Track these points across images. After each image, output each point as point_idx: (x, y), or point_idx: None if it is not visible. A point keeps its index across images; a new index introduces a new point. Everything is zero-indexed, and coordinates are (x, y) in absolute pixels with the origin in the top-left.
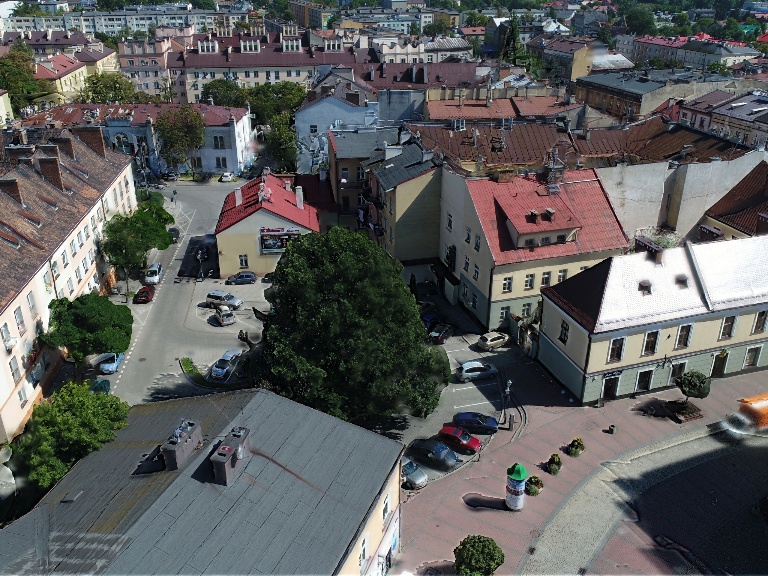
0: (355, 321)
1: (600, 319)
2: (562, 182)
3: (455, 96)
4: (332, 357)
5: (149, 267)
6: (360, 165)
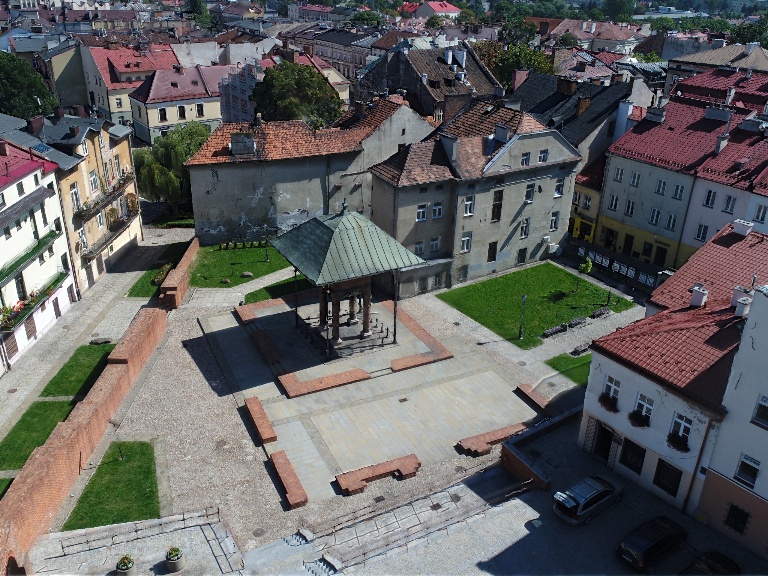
0: (12, 91)
1: (150, 98)
2: (150, 50)
3: (115, 27)
4: (3, 110)
5: None
6: (34, 57)
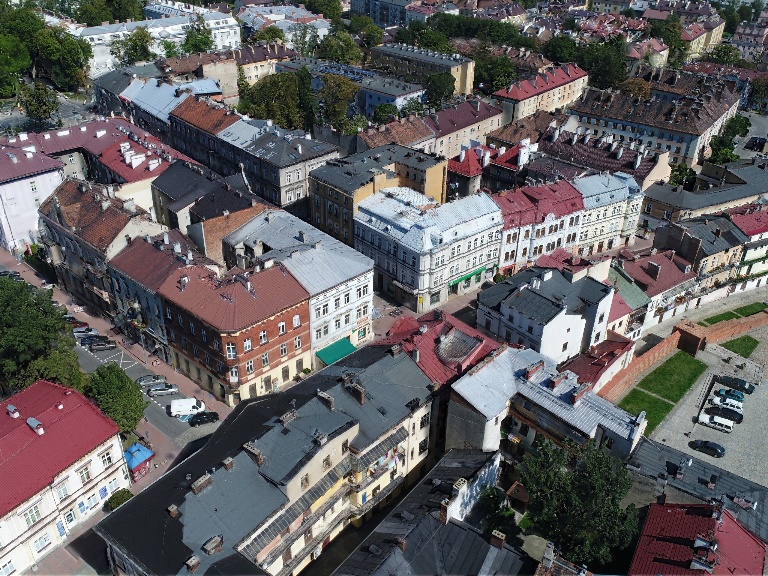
0: None
1: None
2: None
3: None
4: None
5: (734, 141)
6: None
